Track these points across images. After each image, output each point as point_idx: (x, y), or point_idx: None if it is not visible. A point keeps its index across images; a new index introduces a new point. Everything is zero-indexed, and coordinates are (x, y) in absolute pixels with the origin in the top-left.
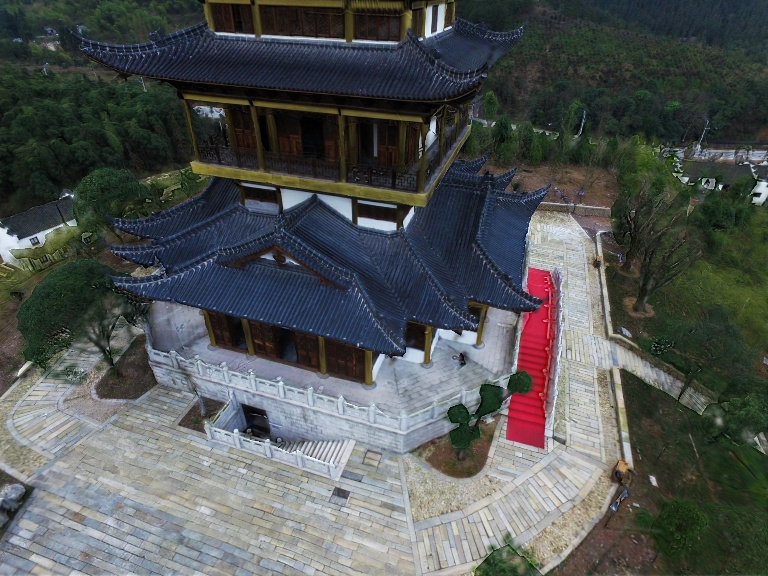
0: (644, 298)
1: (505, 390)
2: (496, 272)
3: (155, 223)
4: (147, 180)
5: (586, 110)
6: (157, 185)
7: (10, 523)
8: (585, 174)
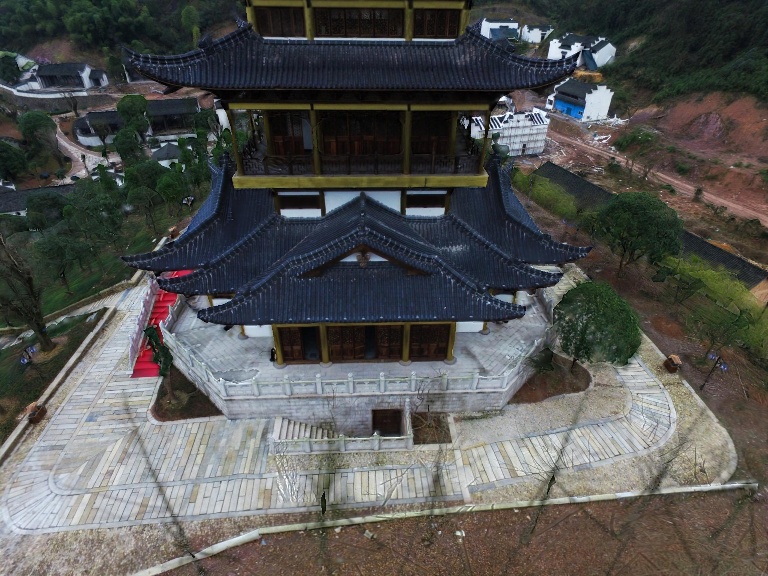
0: None
1: None
2: None
3: None
4: None
5: None
6: None
7: None
8: None
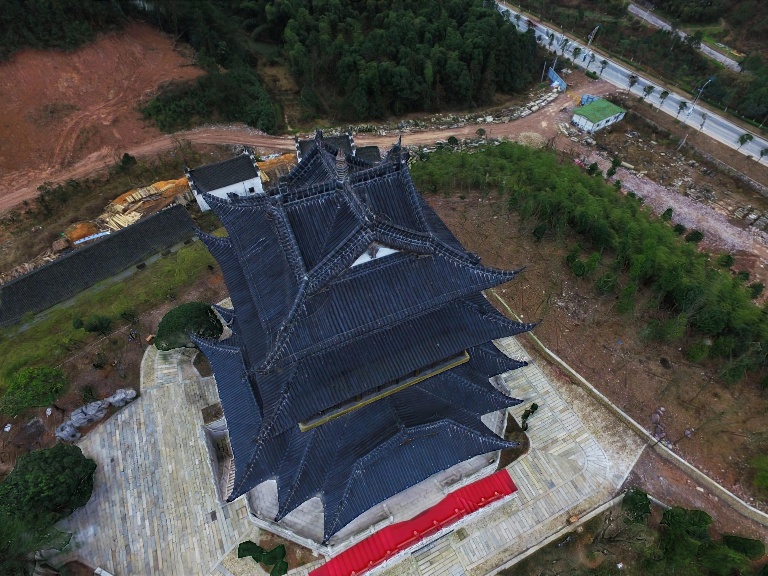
0: None
1: None
2: None
3: None
4: (433, 117)
5: None
6: None
7: (124, 407)
8: (739, 412)
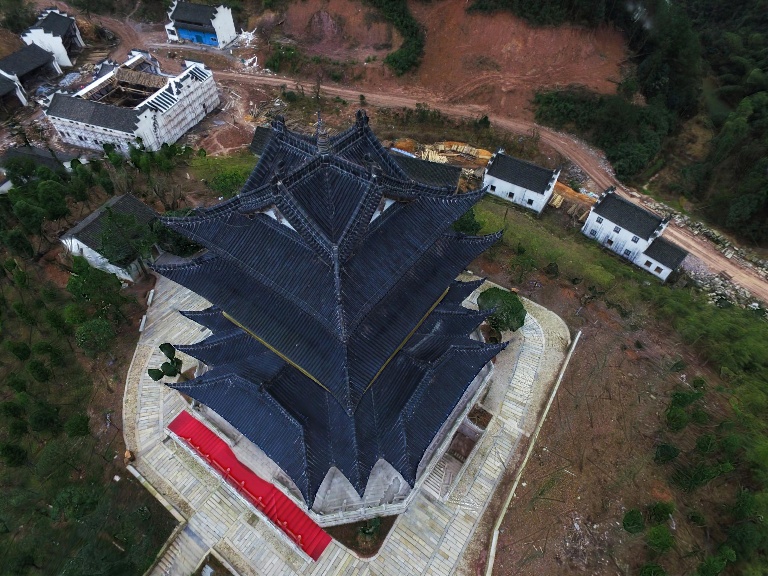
0: None
1: (165, 374)
2: None
3: None
4: None
5: None
6: (550, 253)
7: None
8: None
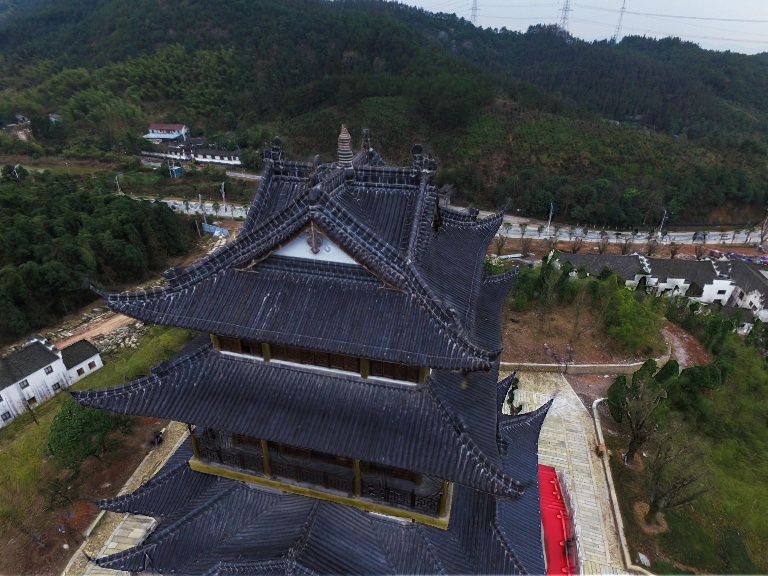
0: (656, 513)
1: None
2: (520, 570)
3: (144, 494)
4: None
5: (552, 198)
6: (138, 363)
7: None
8: (570, 320)
